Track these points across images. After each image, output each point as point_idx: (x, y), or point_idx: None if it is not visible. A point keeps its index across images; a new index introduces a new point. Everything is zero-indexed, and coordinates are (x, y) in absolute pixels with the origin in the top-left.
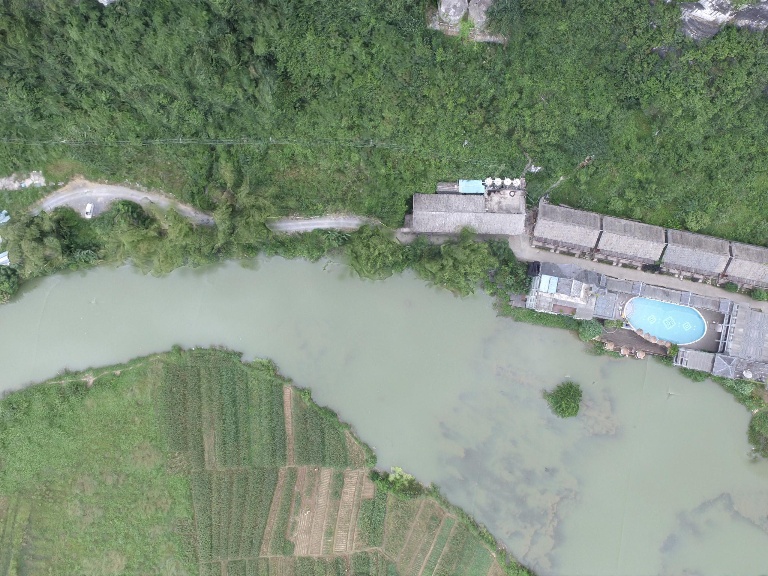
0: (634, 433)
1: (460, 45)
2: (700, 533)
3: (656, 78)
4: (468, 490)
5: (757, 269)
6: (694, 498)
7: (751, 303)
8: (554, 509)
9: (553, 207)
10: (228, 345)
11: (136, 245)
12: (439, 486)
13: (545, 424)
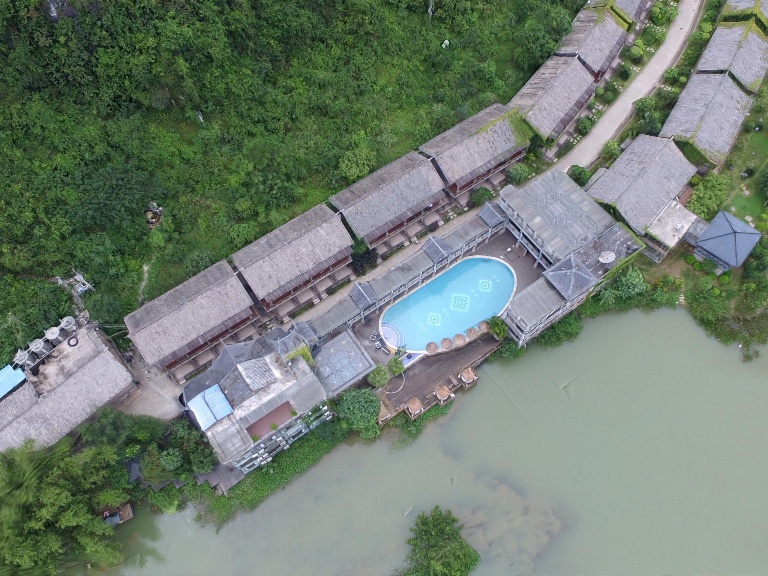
0: (584, 493)
1: None
2: None
3: (103, 48)
4: None
5: (476, 146)
6: (767, 497)
7: None
8: None
9: (147, 306)
10: None
11: None
12: None
13: None
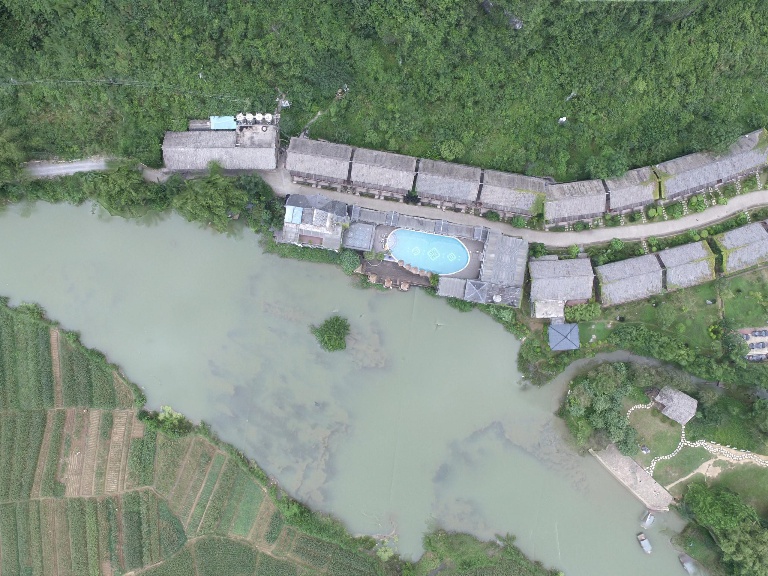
0: (403, 365)
1: None
2: (472, 462)
3: (377, 3)
4: (239, 427)
5: (509, 195)
6: (465, 428)
7: (514, 231)
8: (325, 443)
9: (305, 140)
10: None
11: None
12: (210, 424)
13: (314, 359)
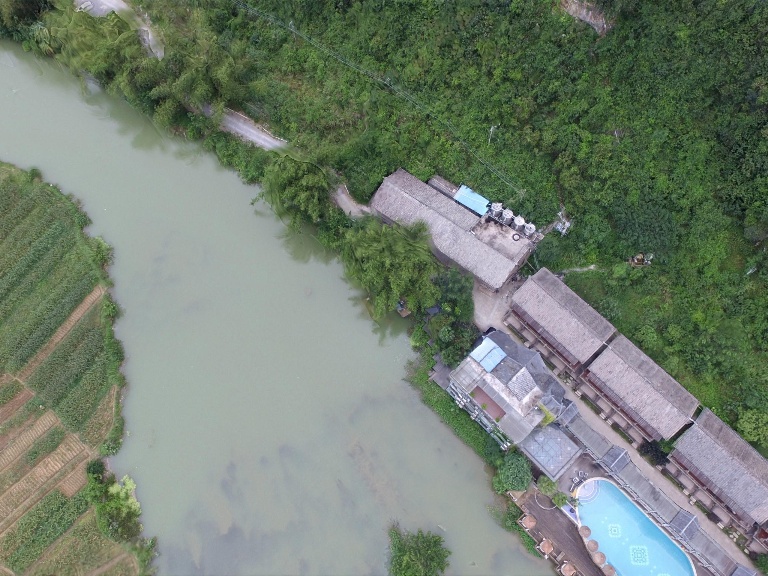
0: None
1: (547, 9)
2: None
3: None
4: None
5: None
6: None
7: None
8: None
9: (558, 281)
10: (87, 204)
11: (80, 30)
12: (161, 551)
13: (365, 573)
